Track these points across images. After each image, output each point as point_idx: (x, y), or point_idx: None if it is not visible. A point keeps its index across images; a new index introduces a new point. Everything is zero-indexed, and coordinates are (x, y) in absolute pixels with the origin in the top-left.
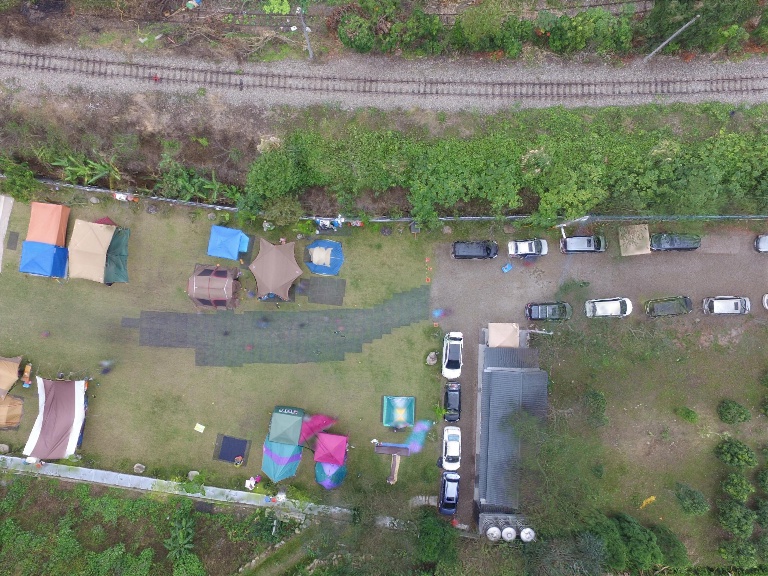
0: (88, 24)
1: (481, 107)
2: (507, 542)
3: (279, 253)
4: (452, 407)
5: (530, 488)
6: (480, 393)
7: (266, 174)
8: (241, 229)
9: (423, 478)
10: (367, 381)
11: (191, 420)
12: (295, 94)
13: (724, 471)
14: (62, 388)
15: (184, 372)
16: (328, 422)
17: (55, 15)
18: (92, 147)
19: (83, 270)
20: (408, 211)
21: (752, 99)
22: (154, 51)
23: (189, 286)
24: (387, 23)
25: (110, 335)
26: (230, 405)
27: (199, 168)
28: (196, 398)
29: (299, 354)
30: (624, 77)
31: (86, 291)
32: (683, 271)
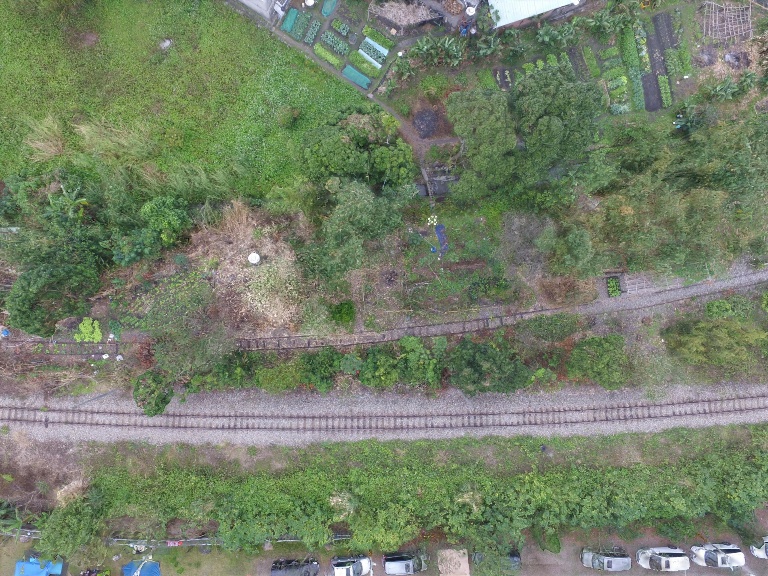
0: None
1: (292, 441)
2: None
3: None
4: None
5: None
6: None
7: (55, 540)
8: None
9: None
10: None
11: None
12: (102, 430)
13: None
14: None
15: None
16: None
17: None
18: None
19: None
20: None
21: (564, 432)
22: None
23: None
24: (186, 377)
25: None
26: None
27: (6, 499)
28: None
29: None
30: (437, 410)
31: None
32: None
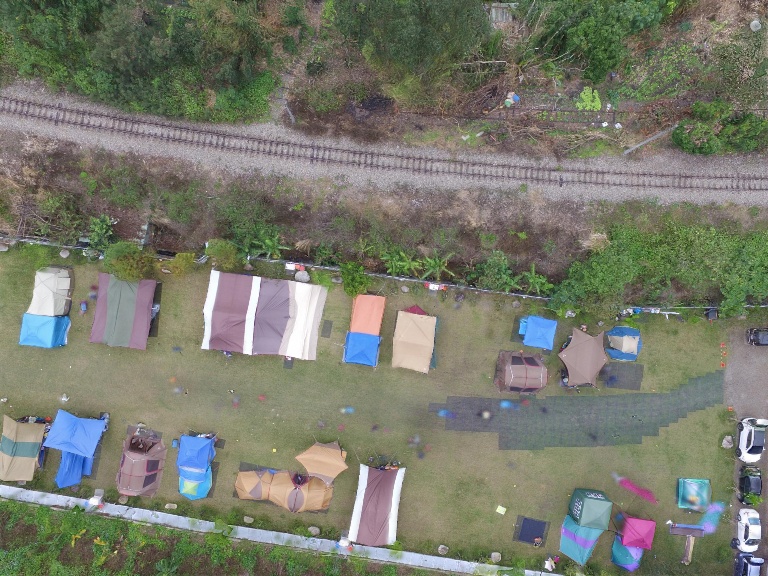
0: (409, 121)
1: None
2: None
3: (595, 344)
4: (754, 491)
5: None
6: None
7: None
8: (543, 316)
9: (717, 559)
10: (663, 464)
11: (493, 502)
12: (613, 190)
13: None
14: (387, 476)
15: (487, 456)
16: (625, 504)
17: (379, 113)
18: None
19: (403, 359)
20: (708, 299)
21: None
22: (477, 148)
23: (506, 375)
24: (719, 126)
25: (417, 420)
26: (531, 487)
27: (513, 260)
28: (498, 481)
29: (598, 438)
30: None
31: (396, 377)
32: None
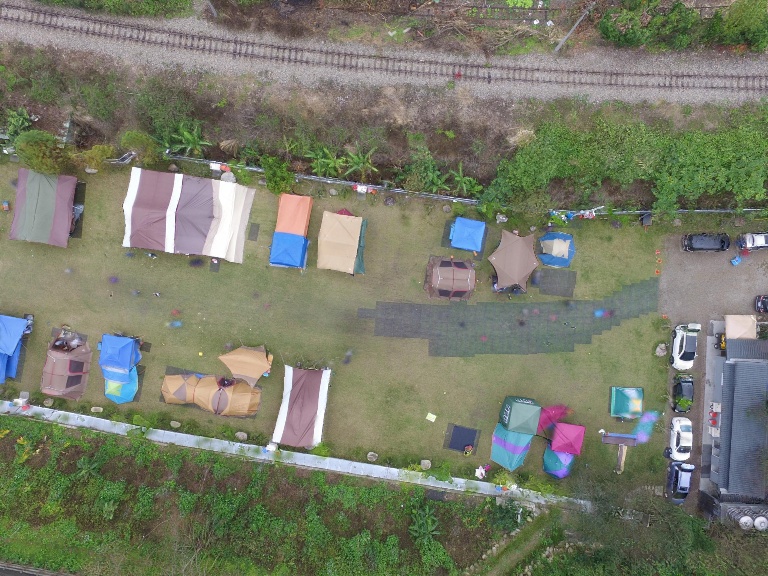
0: (336, 18)
1: (726, 100)
2: (759, 531)
3: (524, 245)
4: (686, 398)
5: None
6: (708, 384)
7: None
8: None
9: (649, 468)
10: (596, 372)
11: (423, 409)
12: (542, 87)
13: None
14: (311, 377)
15: (417, 362)
16: (557, 412)
17: (304, 9)
18: (339, 139)
19: (329, 261)
20: (642, 204)
21: None
22: (403, 44)
23: (433, 277)
24: (648, 16)
25: (346, 325)
26: (461, 395)
27: (441, 160)
28: (428, 388)
29: (530, 345)
30: None
31: (324, 282)
32: None
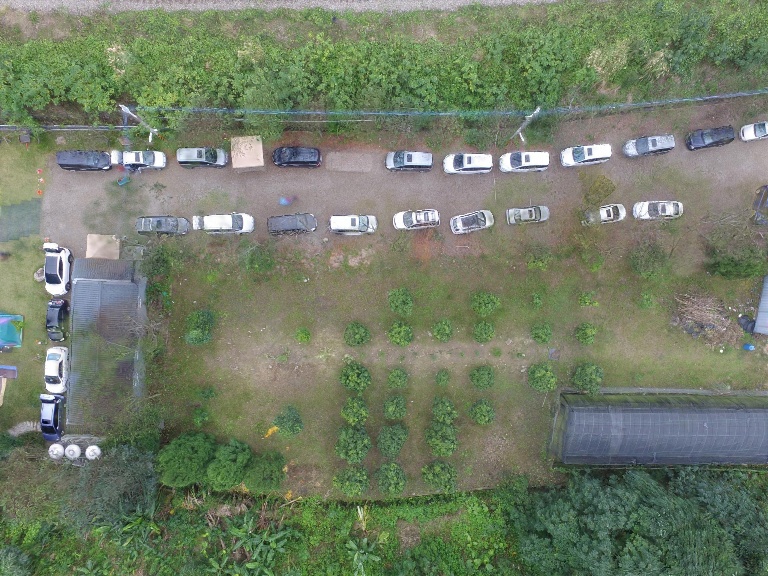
0: None
1: (75, 8)
2: (70, 460)
3: None
4: (51, 324)
5: (108, 405)
6: None
7: None
8: None
9: (30, 402)
10: None
11: None
12: None
13: None
14: None
15: None
16: None
17: None
18: None
19: None
20: None
21: (357, 7)
22: None
23: None
24: None
25: None
26: None
27: None
28: None
29: None
30: None
31: None
32: (312, 189)
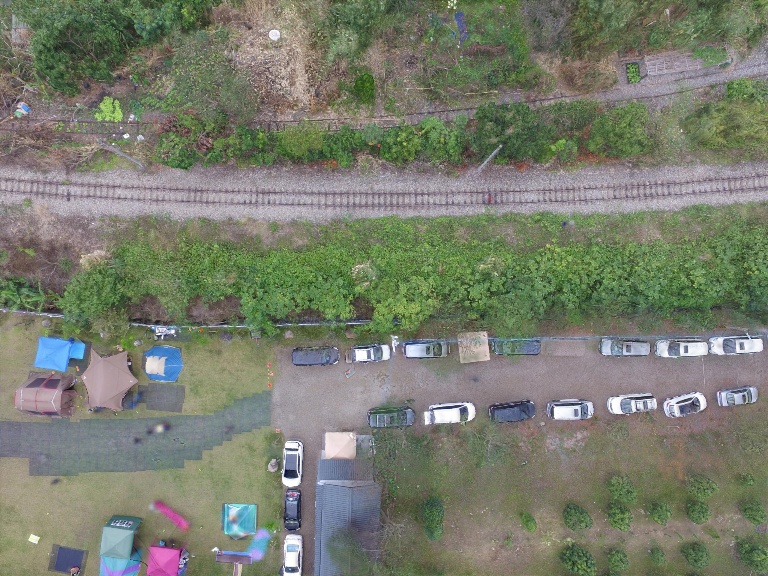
0: None
1: (313, 217)
2: None
3: (108, 365)
4: (290, 517)
5: None
6: None
7: (80, 294)
8: None
9: None
10: (208, 489)
11: (25, 531)
12: (124, 204)
13: (572, 575)
14: None
15: (18, 482)
16: (168, 531)
17: None
18: None
19: None
20: None
21: (585, 209)
22: None
23: (16, 399)
24: (208, 139)
25: None
26: (66, 515)
27: (29, 277)
28: (30, 508)
29: (137, 462)
30: (457, 187)
31: None
32: (528, 374)
